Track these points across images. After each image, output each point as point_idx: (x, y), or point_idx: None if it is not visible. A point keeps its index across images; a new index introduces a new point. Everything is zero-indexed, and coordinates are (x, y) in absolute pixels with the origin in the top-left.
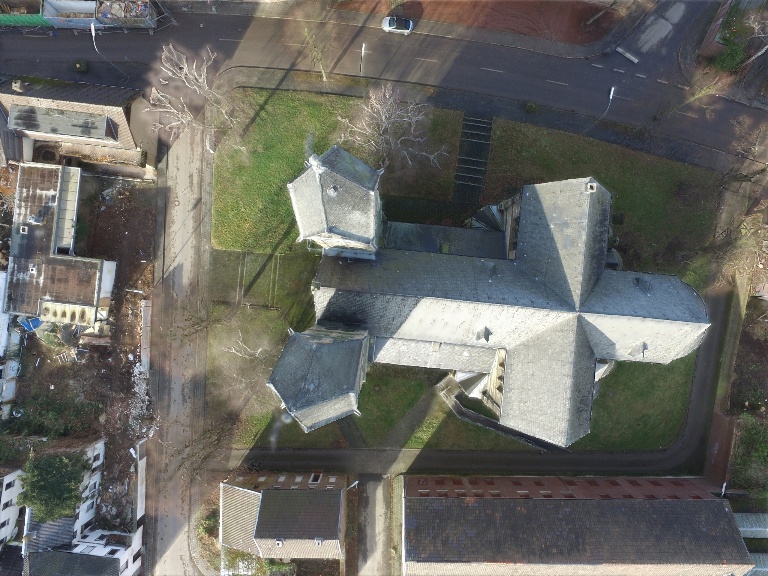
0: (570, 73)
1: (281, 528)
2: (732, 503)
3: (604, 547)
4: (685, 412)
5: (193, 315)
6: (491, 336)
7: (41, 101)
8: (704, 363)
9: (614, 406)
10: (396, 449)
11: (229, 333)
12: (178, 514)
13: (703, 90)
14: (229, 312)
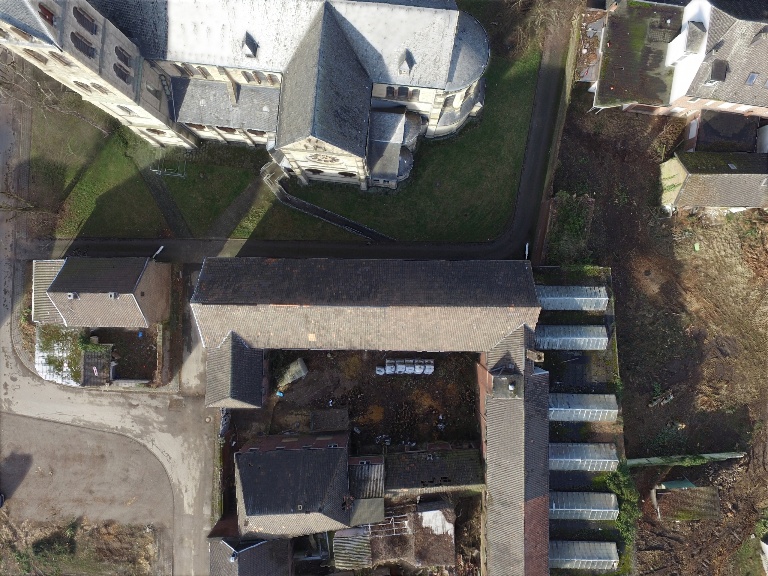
0: None
1: (77, 285)
2: (544, 277)
3: (395, 294)
4: (513, 204)
5: (17, 104)
6: (259, 50)
7: None
8: (533, 155)
9: (441, 196)
10: (222, 239)
11: (53, 120)
12: (0, 305)
13: None
14: (53, 99)
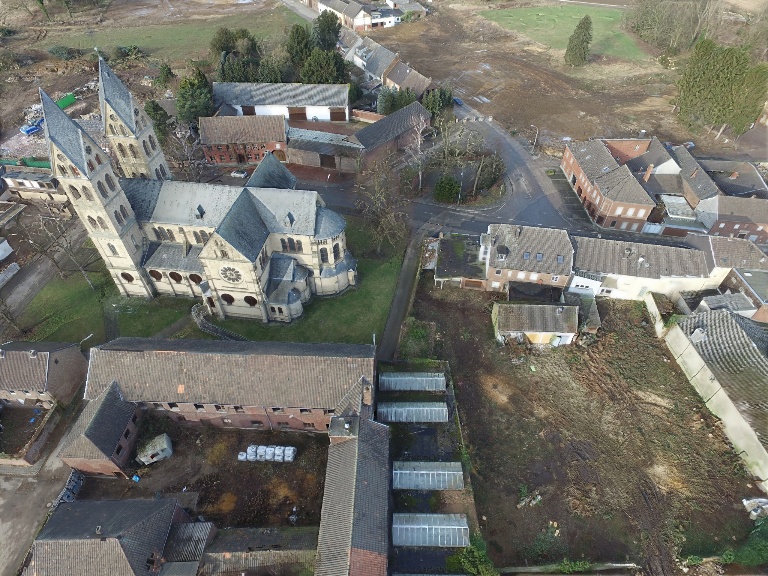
0: (327, 191)
1: None
2: (394, 367)
3: (258, 351)
4: (380, 336)
5: (43, 276)
6: (205, 215)
7: (27, 168)
8: (396, 309)
9: (324, 329)
10: None
11: (61, 283)
12: None
13: (357, 158)
14: (69, 273)
